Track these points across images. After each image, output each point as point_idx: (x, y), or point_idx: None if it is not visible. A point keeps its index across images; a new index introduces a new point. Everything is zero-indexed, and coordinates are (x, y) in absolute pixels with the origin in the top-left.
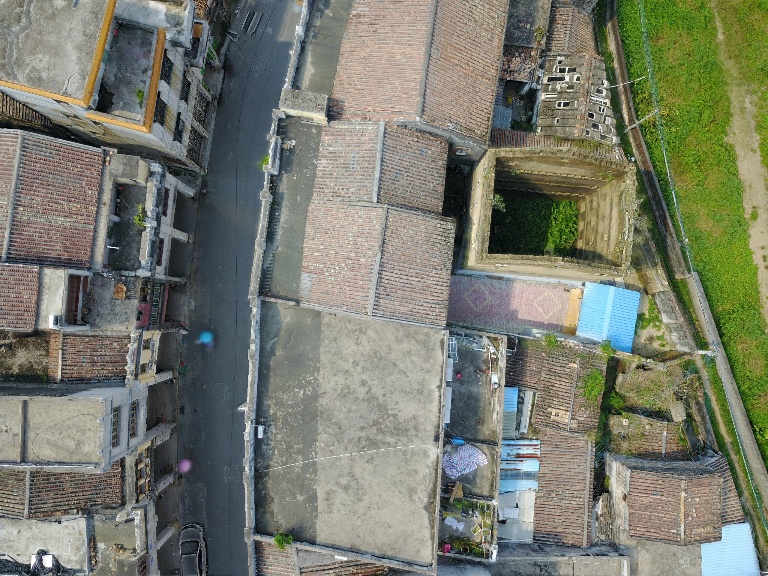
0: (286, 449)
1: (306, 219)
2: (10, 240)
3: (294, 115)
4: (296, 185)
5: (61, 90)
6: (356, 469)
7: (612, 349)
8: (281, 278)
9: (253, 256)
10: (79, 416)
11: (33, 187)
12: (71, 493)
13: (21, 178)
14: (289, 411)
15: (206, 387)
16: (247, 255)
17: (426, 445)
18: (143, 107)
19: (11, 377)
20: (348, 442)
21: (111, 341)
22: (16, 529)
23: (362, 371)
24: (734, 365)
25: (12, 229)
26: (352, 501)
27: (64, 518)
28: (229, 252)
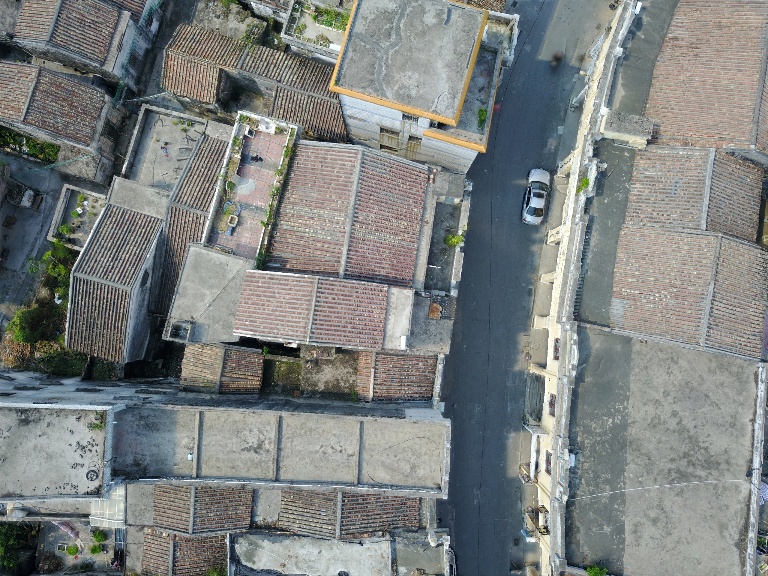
0: (593, 478)
1: (618, 244)
2: (347, 257)
3: (608, 137)
4: (607, 209)
5: (430, 108)
6: (665, 502)
7: None
8: (590, 303)
9: (507, 275)
10: (415, 439)
11: (369, 204)
12: (376, 515)
13: (359, 194)
14: (597, 439)
15: (457, 407)
16: (501, 274)
17: (738, 480)
18: (486, 126)
19: (317, 394)
20: (658, 474)
21: (418, 361)
22: (317, 549)
23: (673, 401)
24: None
25: (349, 246)
26: (661, 535)
27: (368, 540)
28: (483, 271)
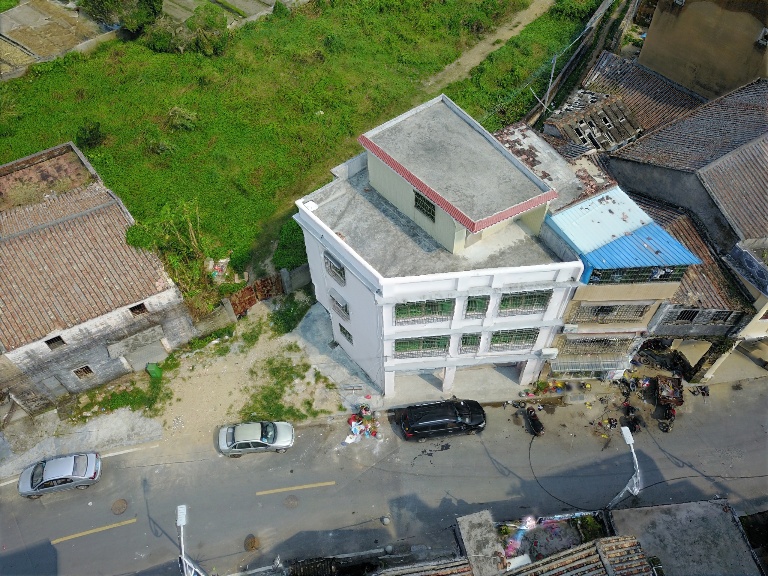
0: None
1: None
2: None
3: None
4: None
5: None
6: None
7: None
8: None
9: None
10: None
11: None
12: None
13: None
14: None
15: None
16: None
17: None
18: None
19: None
20: None
21: None
22: None
23: None
24: None
25: None
26: None
27: None
28: None
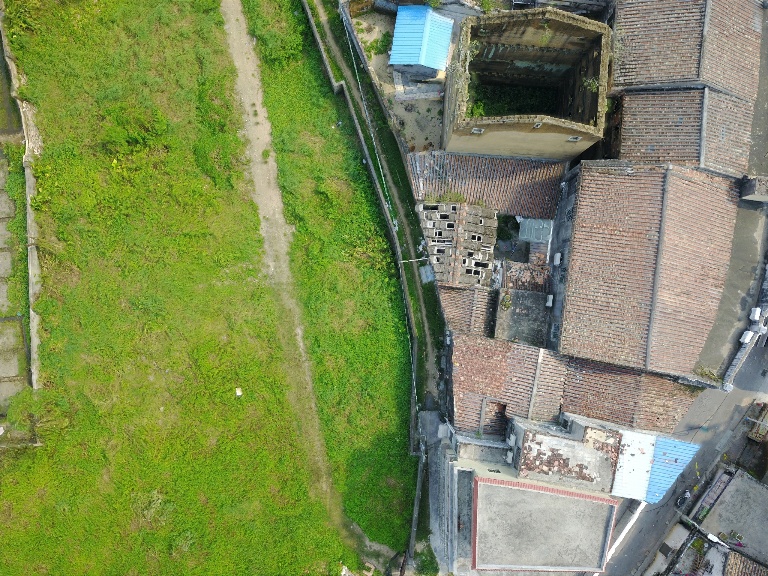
0: None
1: (759, 85)
2: None
3: None
4: None
5: None
6: None
7: (425, 1)
8: None
9: None
10: None
11: None
12: None
13: None
14: None
15: None
16: None
17: None
18: None
19: None
20: None
21: None
22: None
23: None
24: (291, 5)
25: None
26: None
27: None
28: None
